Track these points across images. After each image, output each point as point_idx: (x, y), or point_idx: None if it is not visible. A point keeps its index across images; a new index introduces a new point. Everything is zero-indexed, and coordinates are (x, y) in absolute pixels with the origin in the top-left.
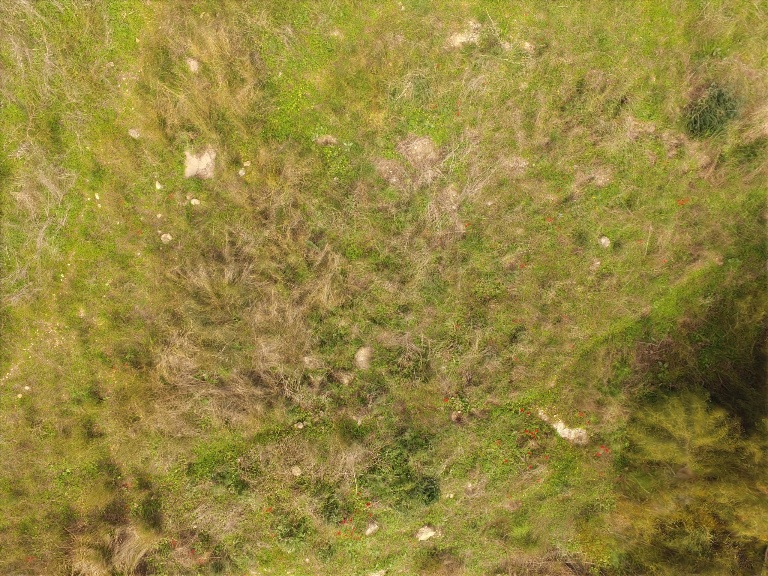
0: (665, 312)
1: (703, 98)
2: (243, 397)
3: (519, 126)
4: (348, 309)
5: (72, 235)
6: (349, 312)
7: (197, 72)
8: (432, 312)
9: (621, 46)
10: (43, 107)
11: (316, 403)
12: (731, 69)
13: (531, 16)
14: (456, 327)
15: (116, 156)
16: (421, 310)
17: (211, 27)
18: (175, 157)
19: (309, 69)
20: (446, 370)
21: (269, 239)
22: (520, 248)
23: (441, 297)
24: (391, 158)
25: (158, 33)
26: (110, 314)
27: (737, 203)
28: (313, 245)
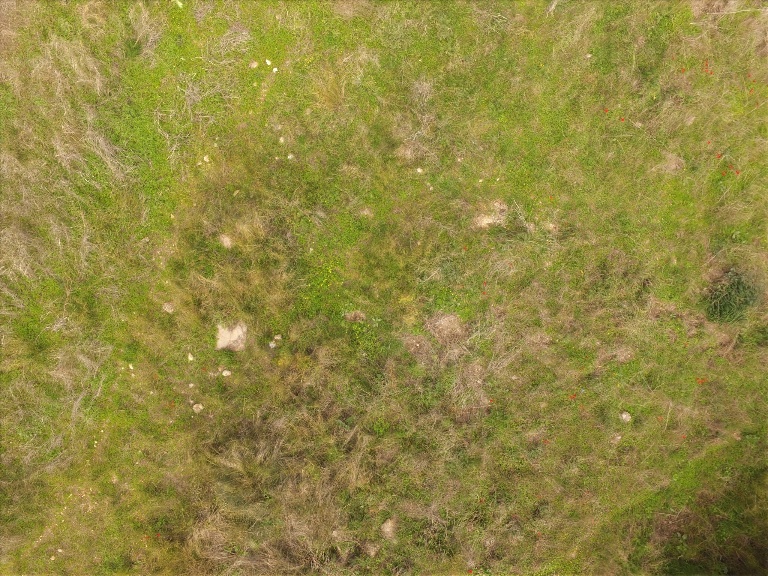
0: (684, 484)
1: (723, 285)
2: (272, 568)
3: (543, 305)
4: (376, 485)
5: (106, 404)
6: (377, 489)
7: (230, 247)
8: (457, 485)
9: (643, 229)
10: (80, 282)
11: (343, 574)
12: (750, 256)
13: (556, 198)
14: (480, 498)
15: (151, 331)
16: (446, 482)
17: (244, 206)
18: (208, 331)
19: (339, 246)
20: (470, 540)
21: (300, 421)
22: (543, 424)
23: (466, 470)
24: (418, 334)
25: (193, 215)
26: (142, 480)
27: (755, 381)
28: (342, 424)
